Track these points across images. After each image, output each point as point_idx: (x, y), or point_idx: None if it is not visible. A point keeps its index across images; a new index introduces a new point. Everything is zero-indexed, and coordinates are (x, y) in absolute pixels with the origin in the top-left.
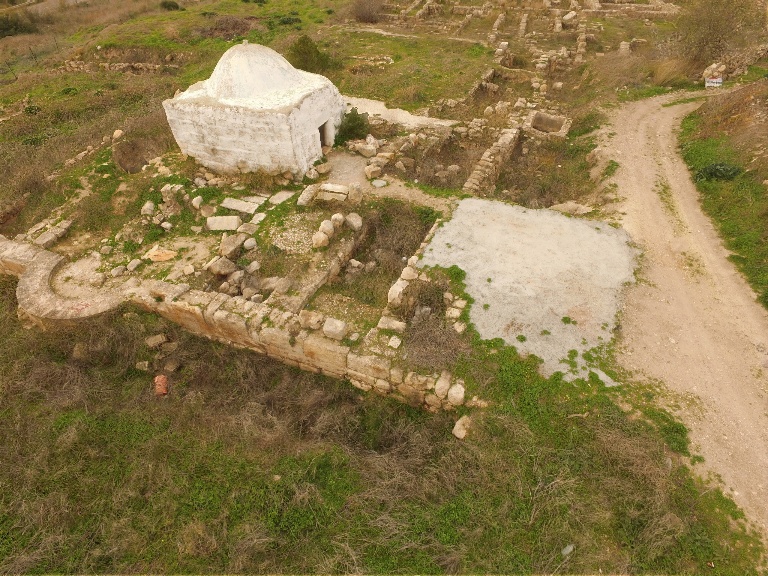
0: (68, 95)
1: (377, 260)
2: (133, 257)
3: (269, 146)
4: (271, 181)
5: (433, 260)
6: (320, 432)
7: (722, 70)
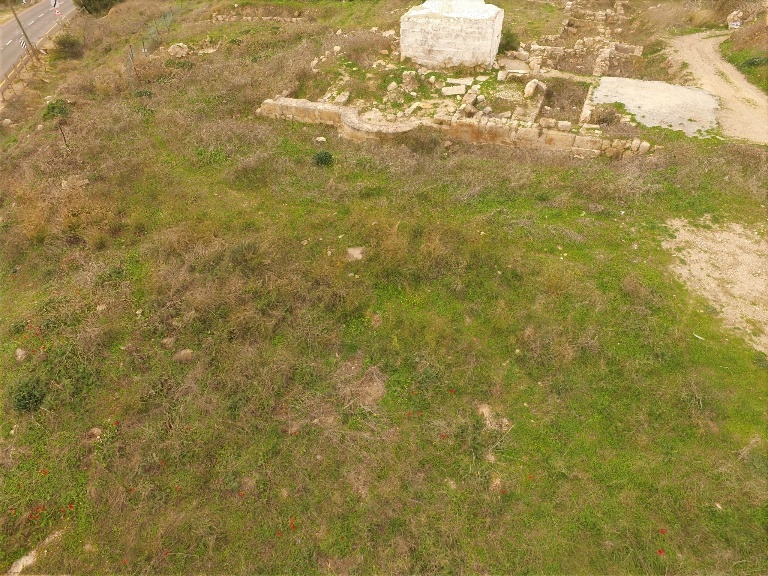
0: (248, 35)
1: (561, 106)
2: (401, 110)
3: (474, 45)
4: (473, 69)
5: (601, 101)
6: (587, 154)
7: (740, 16)
